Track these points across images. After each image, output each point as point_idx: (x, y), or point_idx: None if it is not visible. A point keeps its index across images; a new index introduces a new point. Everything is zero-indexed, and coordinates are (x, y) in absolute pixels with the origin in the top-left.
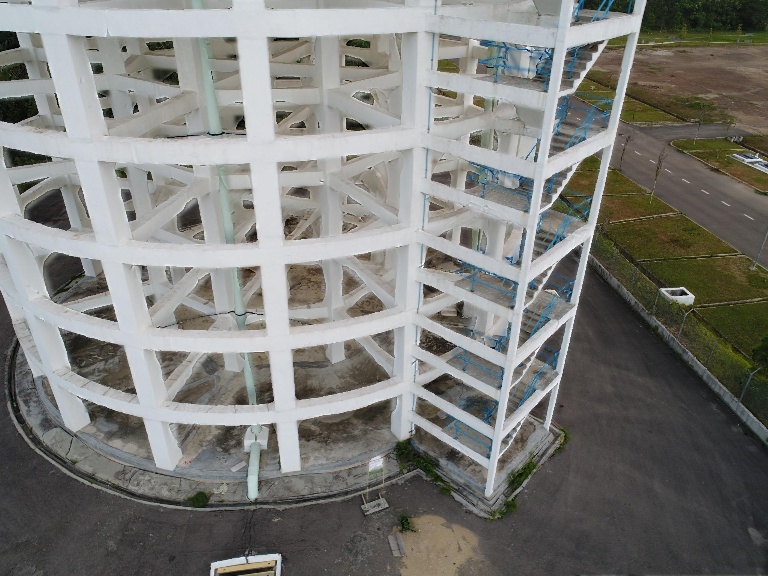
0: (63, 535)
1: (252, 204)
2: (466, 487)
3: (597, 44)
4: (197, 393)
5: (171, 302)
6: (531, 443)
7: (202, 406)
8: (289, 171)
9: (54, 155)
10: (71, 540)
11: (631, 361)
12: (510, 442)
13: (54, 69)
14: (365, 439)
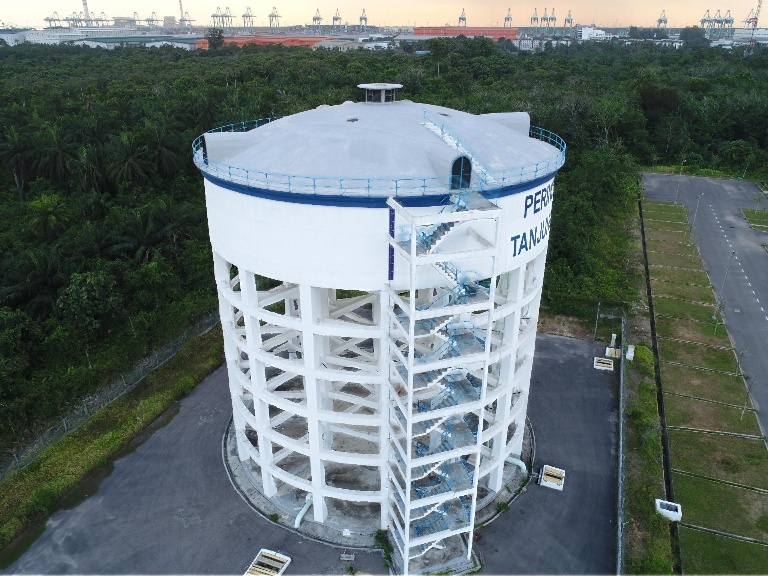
0: (216, 509)
1: None
2: (398, 569)
3: (447, 368)
4: (302, 461)
5: (286, 416)
6: (451, 562)
7: (284, 471)
8: (362, 362)
9: (243, 350)
10: (217, 512)
11: (575, 542)
12: (423, 553)
13: (246, 324)
14: (365, 520)
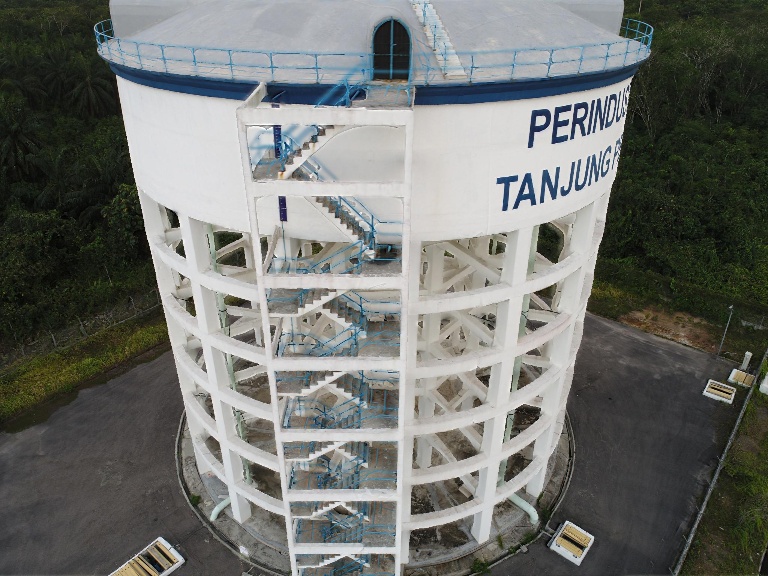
0: (143, 471)
1: None
2: None
3: None
4: (260, 438)
5: None
6: None
7: (206, 449)
8: None
9: None
10: (142, 476)
11: None
12: None
13: None
14: None
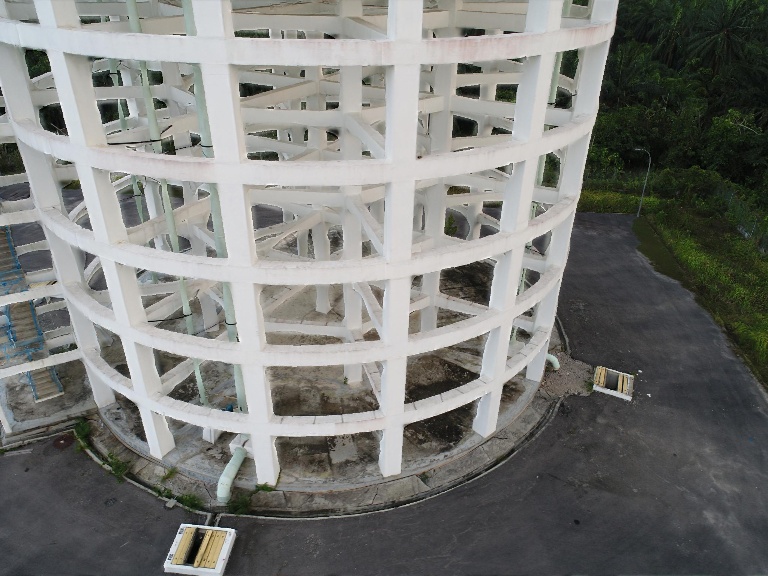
0: None
1: (597, 318)
2: None
3: None
4: None
5: None
6: (6, 411)
7: None
8: None
9: None
10: None
11: None
12: None
13: None
14: None
